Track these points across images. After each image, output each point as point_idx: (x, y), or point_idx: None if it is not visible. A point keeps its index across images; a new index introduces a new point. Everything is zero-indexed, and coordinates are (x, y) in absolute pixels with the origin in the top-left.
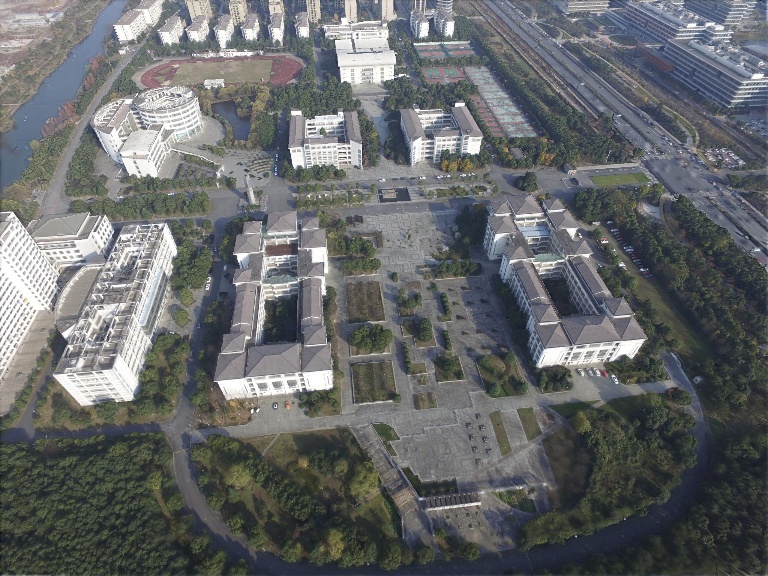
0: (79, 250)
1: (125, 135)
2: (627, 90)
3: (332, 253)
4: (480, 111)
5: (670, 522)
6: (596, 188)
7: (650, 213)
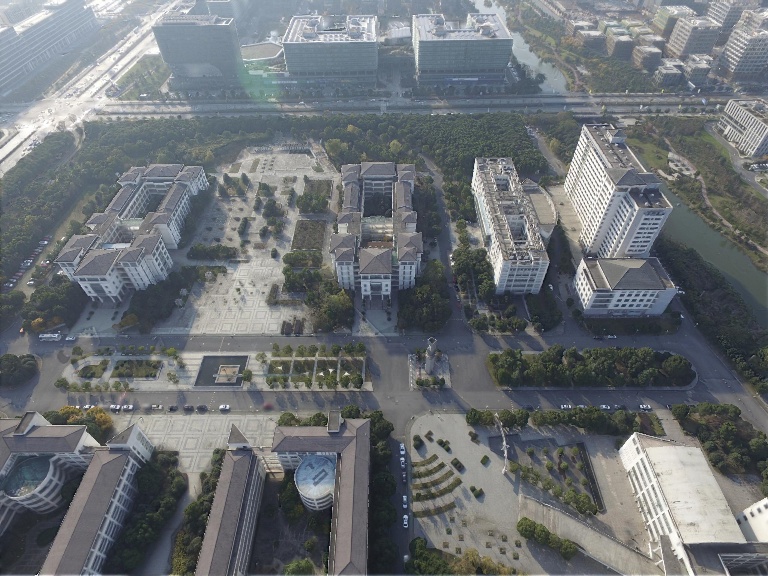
0: None
1: (766, 553)
2: None
3: None
4: None
5: (205, 131)
6: None
7: None
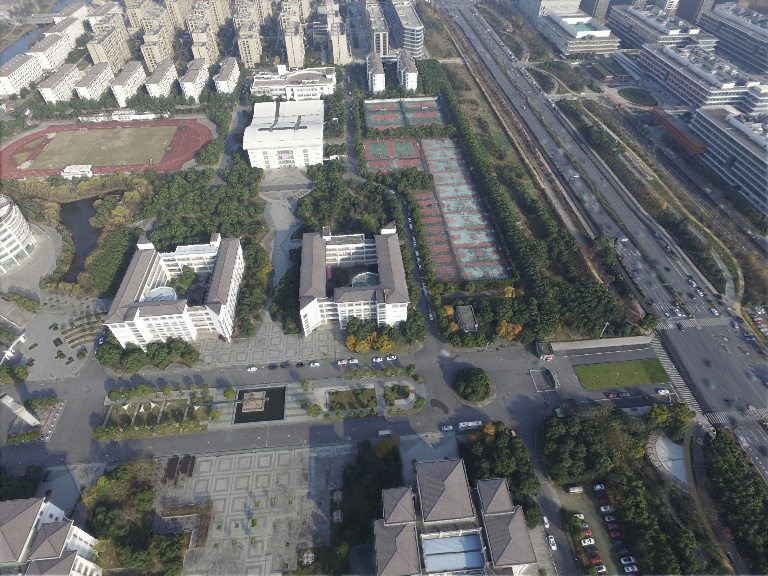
0: None
1: None
2: (638, 185)
3: (113, 562)
4: (429, 221)
5: None
6: (582, 396)
7: (668, 462)
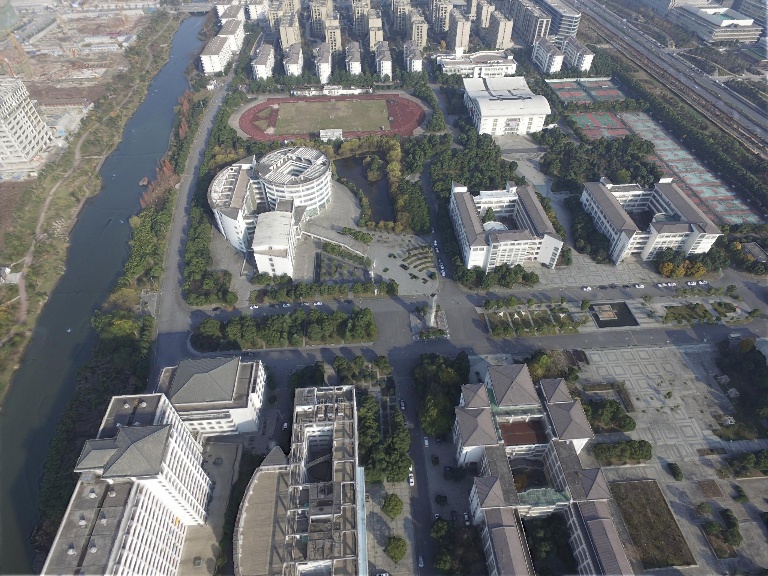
0: (232, 419)
1: (250, 216)
2: None
3: None
4: None
5: None
6: None
7: None
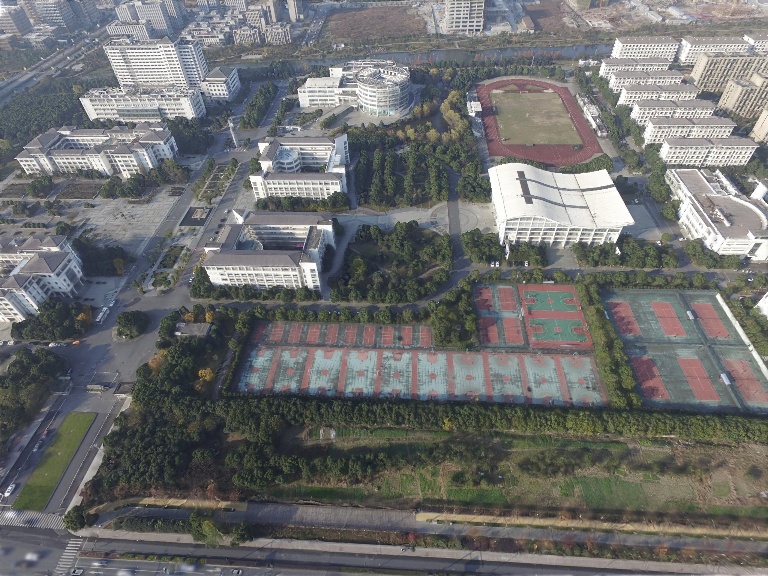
0: None
1: None
2: None
3: None
4: (366, 332)
5: None
6: None
7: None
